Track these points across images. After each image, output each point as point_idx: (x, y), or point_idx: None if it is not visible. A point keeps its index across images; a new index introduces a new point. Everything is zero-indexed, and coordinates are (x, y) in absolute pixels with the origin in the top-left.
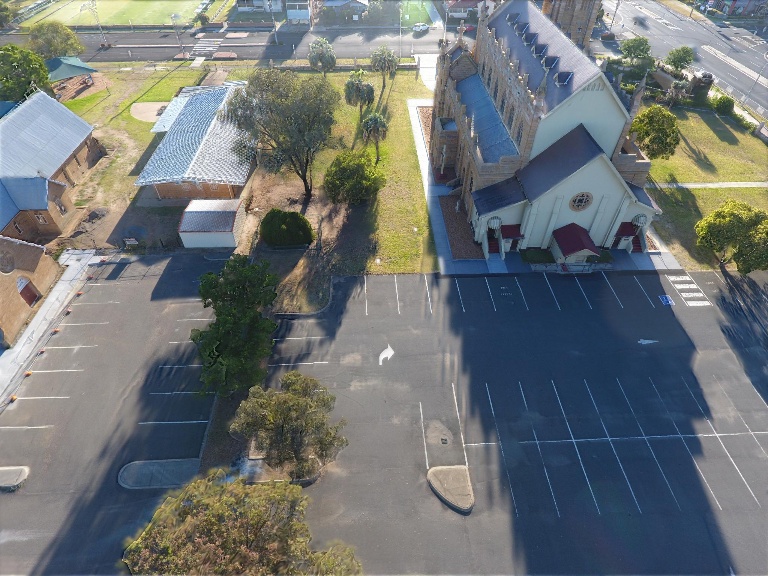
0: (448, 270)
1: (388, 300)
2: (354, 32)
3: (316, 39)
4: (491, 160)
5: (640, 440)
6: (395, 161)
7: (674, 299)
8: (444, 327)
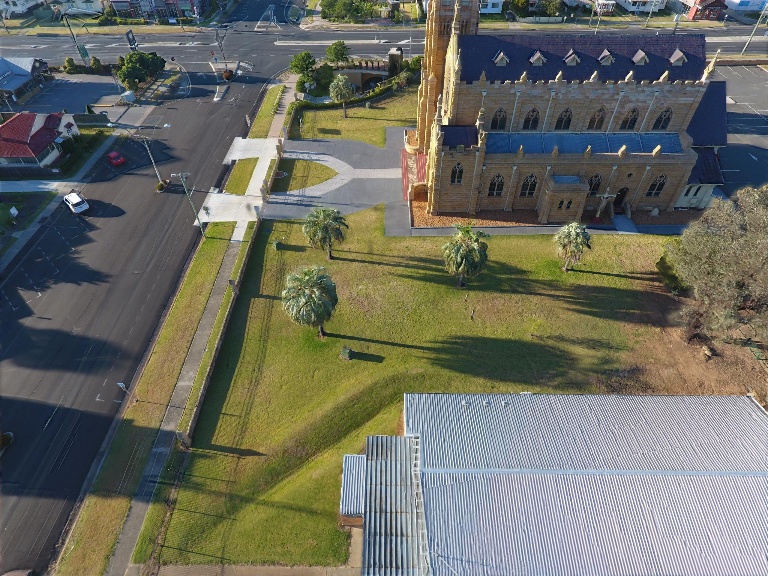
0: None
1: None
2: (7, 298)
3: (15, 364)
4: None
5: None
6: None
7: None
8: None
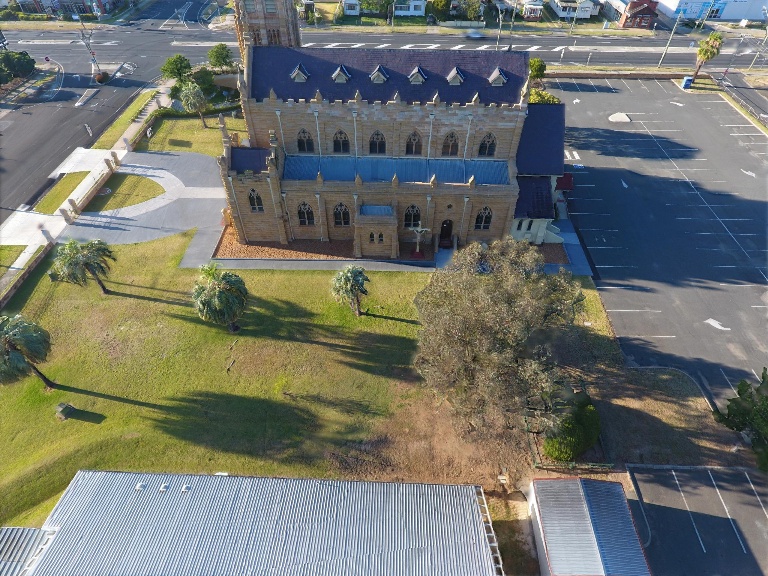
0: (586, 270)
1: (647, 318)
2: None
3: None
4: (494, 183)
5: (712, 208)
6: (373, 294)
7: (576, 163)
8: (664, 282)
